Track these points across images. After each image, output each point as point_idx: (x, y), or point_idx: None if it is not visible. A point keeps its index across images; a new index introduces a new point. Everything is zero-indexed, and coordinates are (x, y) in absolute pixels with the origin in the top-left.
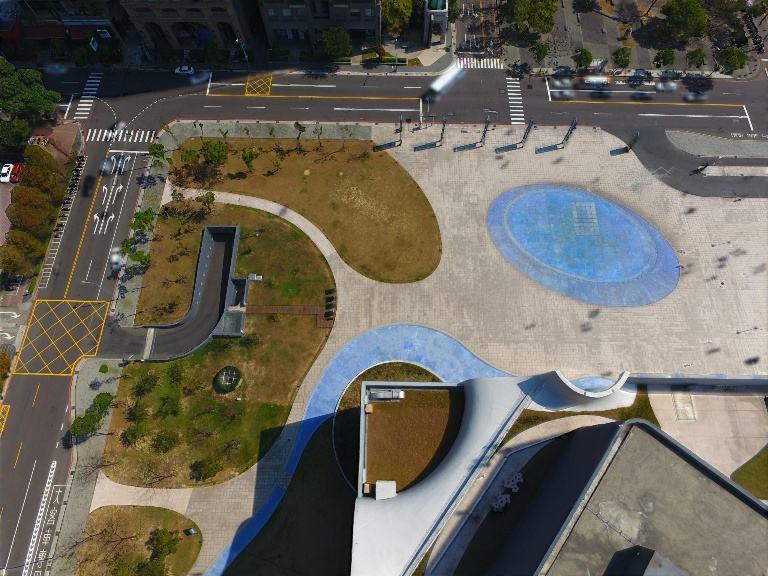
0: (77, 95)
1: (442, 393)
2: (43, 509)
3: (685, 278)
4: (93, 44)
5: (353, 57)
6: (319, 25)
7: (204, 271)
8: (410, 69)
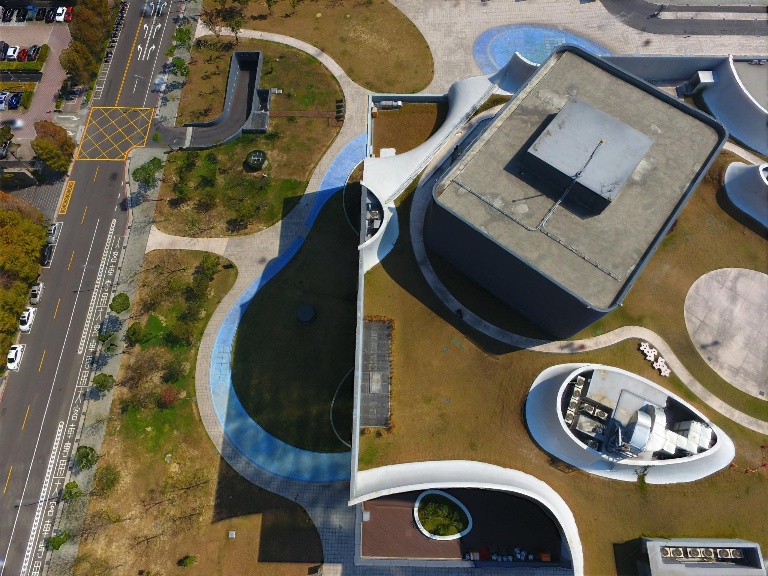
0: None
1: (431, 104)
2: (107, 252)
3: None
4: None
5: None
6: None
7: (233, 88)
8: None
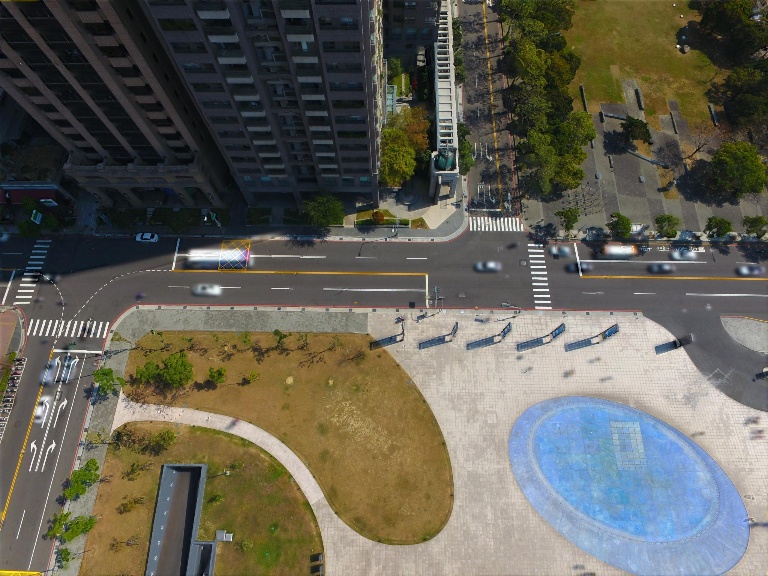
0: (19, 271)
1: None
2: None
3: (756, 537)
4: (35, 217)
5: (346, 217)
6: (305, 188)
7: (162, 523)
8: (413, 233)
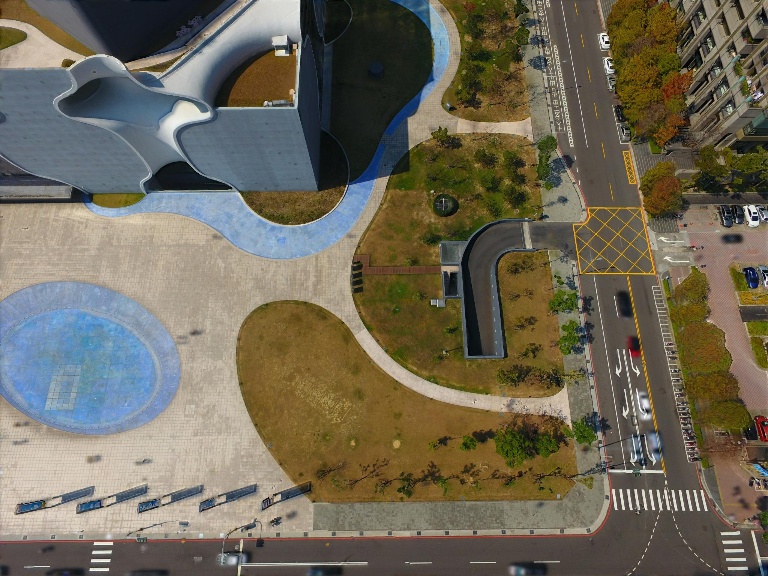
0: None
1: None
2: (567, 119)
3: None
4: None
5: None
6: None
7: (495, 312)
8: None
